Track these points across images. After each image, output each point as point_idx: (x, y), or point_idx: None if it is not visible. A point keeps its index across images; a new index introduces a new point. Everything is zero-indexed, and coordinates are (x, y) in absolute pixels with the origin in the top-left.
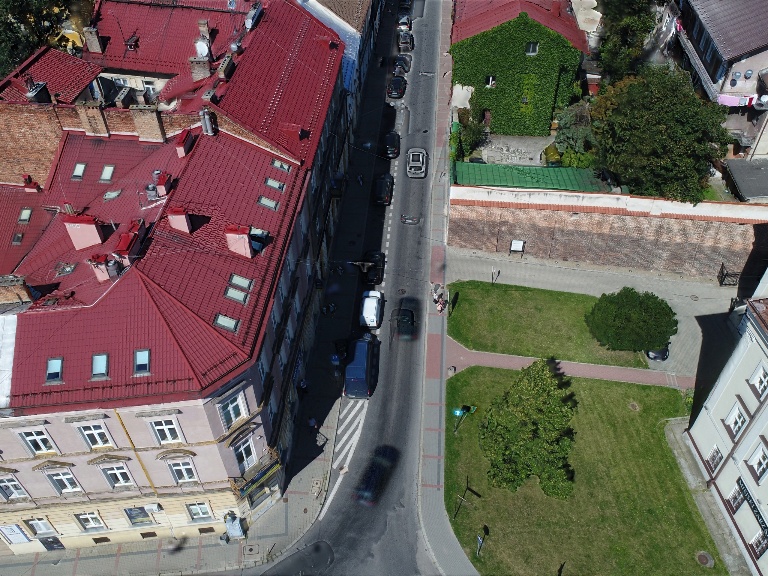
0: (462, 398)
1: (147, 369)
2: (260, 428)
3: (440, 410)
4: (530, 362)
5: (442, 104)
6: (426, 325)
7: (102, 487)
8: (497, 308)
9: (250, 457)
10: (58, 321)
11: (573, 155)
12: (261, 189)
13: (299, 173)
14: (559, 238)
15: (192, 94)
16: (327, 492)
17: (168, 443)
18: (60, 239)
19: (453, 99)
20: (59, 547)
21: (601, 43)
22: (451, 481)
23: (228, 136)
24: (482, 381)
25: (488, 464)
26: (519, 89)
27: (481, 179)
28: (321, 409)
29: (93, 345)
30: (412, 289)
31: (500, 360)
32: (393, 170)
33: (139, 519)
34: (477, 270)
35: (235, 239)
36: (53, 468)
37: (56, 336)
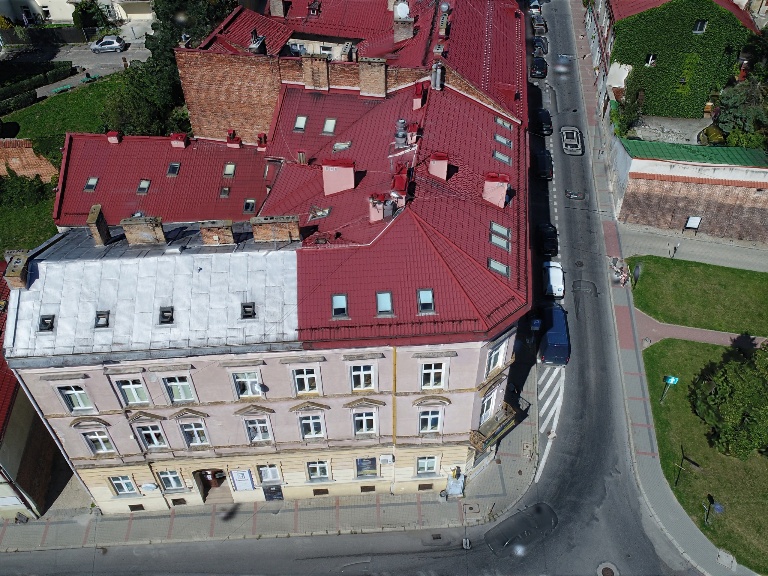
0: (662, 369)
1: (432, 308)
2: (505, 381)
3: (641, 380)
4: (724, 337)
5: (587, 85)
6: (611, 297)
7: (345, 434)
8: (681, 283)
9: (487, 411)
10: (338, 258)
11: (741, 135)
12: (493, 144)
13: (520, 132)
14: (738, 216)
15: (395, 54)
16: (539, 455)
17: (428, 389)
18: (303, 185)
19: (608, 78)
20: (278, 497)
21: (765, 24)
22: (665, 449)
23: (453, 92)
24: (679, 353)
25: (701, 434)
26: (679, 69)
27: (652, 155)
28: (518, 375)
29: (375, 283)
30: (589, 262)
31: (694, 333)
32: (549, 147)
33: (365, 471)
34: (653, 245)
35: (494, 187)
36: (310, 410)
37: (337, 273)
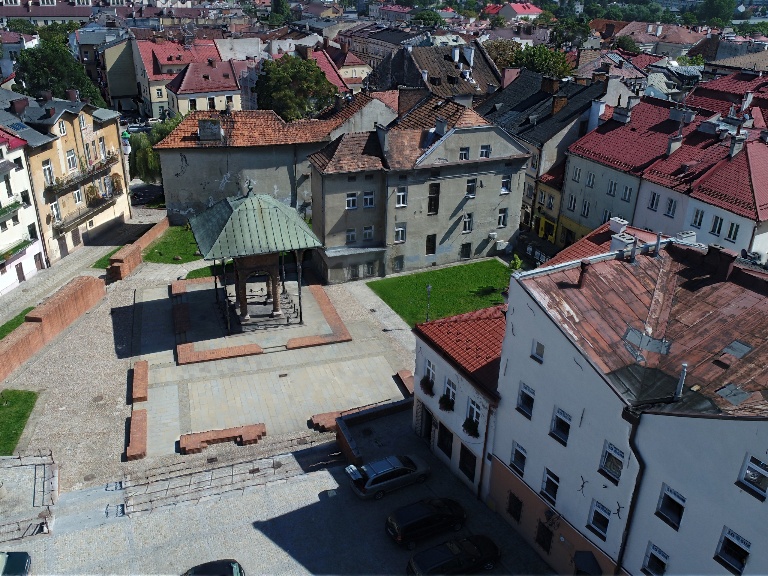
0: None
1: None
2: None
3: None
4: None
5: None
6: None
7: None
8: None
9: None
10: None
11: None
12: None
13: None
14: None
15: None
16: None
17: None
18: None
19: None
20: None
21: None
22: None
23: None
24: None
25: None
26: None
27: None
28: None
29: None
30: None
31: None
32: None
33: None
34: None
35: None
36: None
37: None
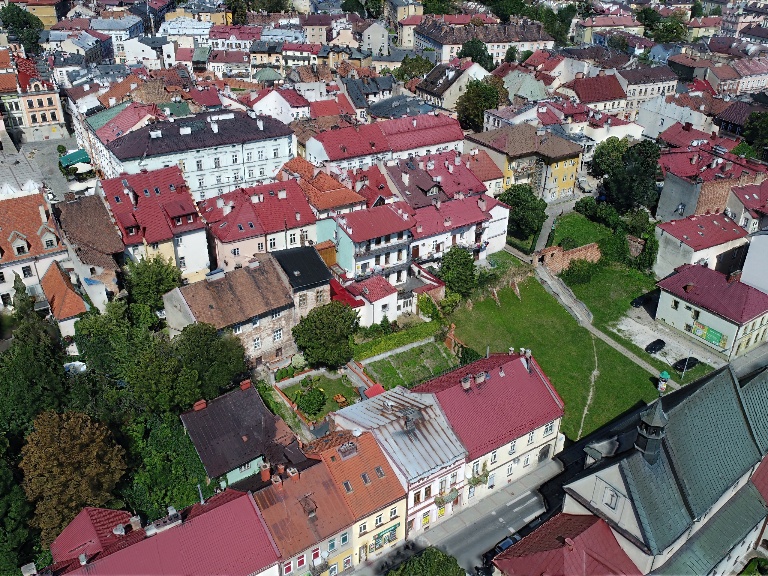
0: None
1: None
2: None
3: None
4: None
5: None
6: None
7: None
8: None
9: None
10: None
11: None
12: None
13: None
14: None
15: None
16: None
17: None
18: None
19: None
20: None
21: None
22: None
23: None
24: None
25: None
26: None
27: None
28: None
29: None
30: None
31: None
32: None
33: None
34: None
35: None
36: None
37: None
